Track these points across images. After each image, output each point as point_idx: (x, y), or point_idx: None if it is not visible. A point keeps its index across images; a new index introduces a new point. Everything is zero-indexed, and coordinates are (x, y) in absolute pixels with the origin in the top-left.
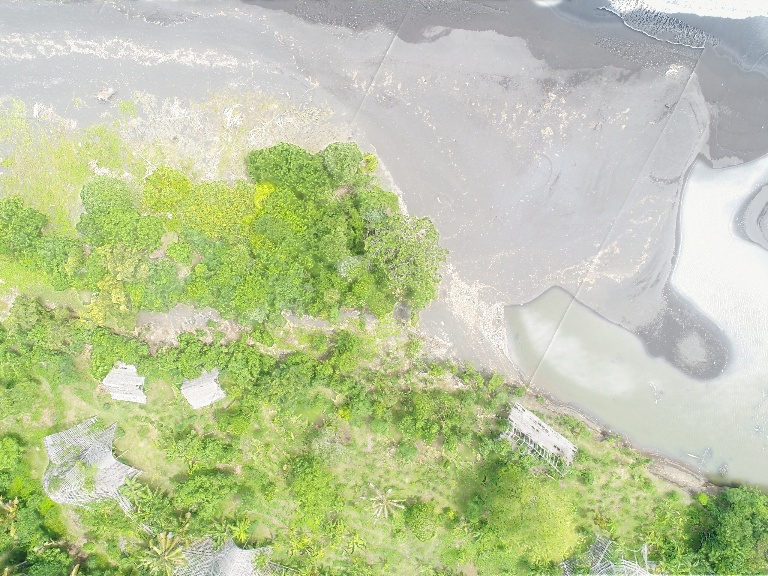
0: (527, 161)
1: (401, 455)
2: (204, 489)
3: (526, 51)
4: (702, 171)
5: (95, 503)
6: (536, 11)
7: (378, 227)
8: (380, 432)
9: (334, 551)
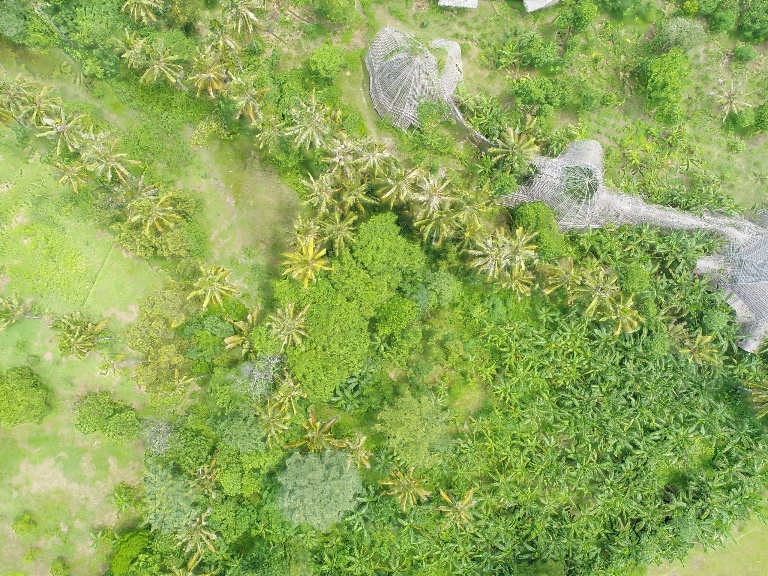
0: None
1: (735, 65)
2: None
3: None
4: None
5: (433, 104)
6: None
7: None
8: (723, 29)
9: (668, 169)
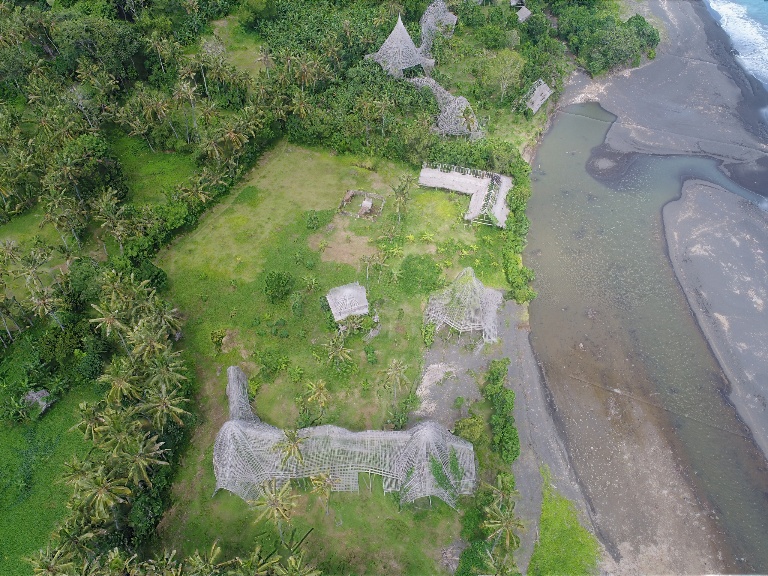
0: (680, 102)
1: None
2: None
3: (738, 100)
4: (713, 163)
5: None
6: (762, 104)
7: None
8: None
9: None
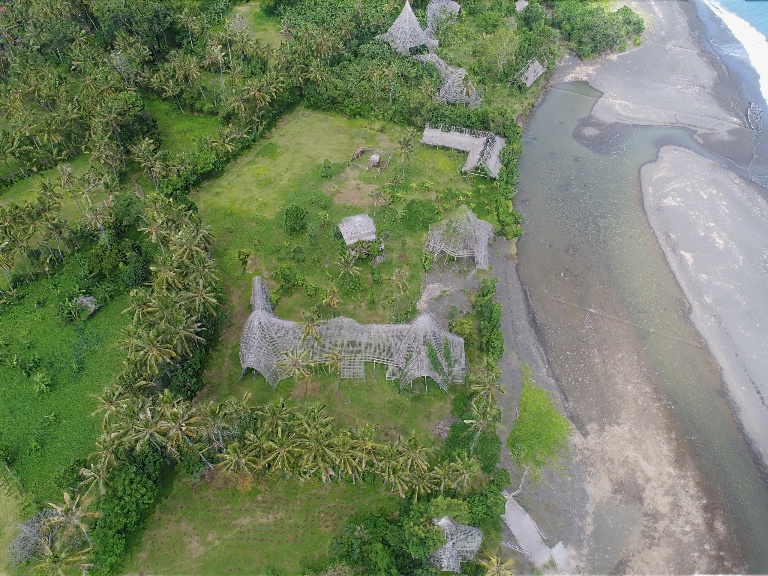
0: (661, 82)
1: None
2: (481, 3)
3: None
4: None
5: None
6: (736, 85)
7: (615, 17)
8: None
9: None
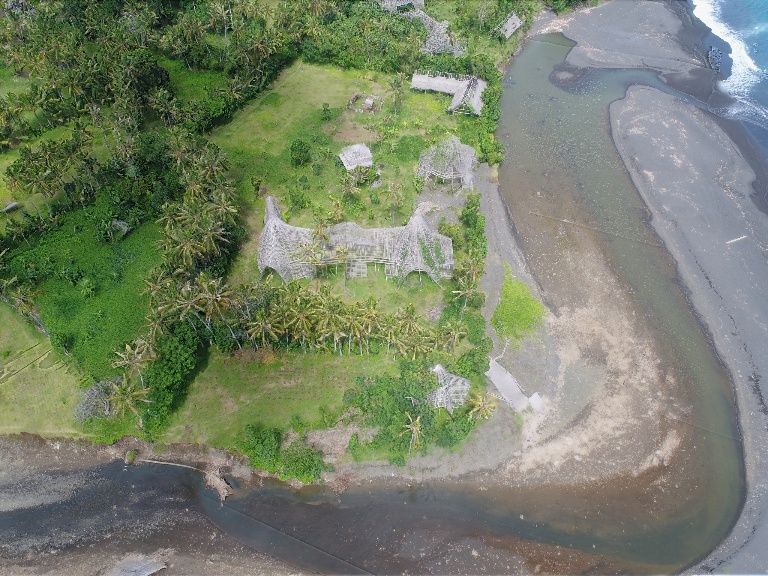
0: (630, 31)
1: None
2: None
3: (679, 29)
4: None
5: None
6: (699, 32)
7: None
8: None
9: None
